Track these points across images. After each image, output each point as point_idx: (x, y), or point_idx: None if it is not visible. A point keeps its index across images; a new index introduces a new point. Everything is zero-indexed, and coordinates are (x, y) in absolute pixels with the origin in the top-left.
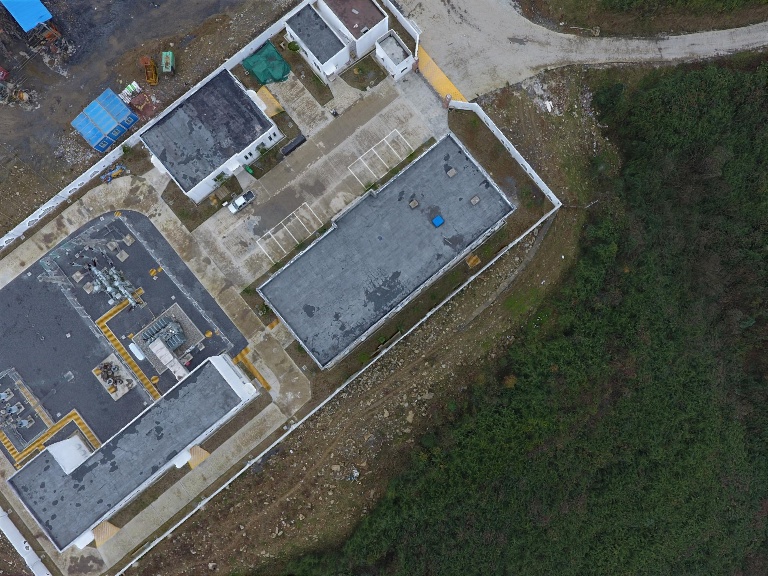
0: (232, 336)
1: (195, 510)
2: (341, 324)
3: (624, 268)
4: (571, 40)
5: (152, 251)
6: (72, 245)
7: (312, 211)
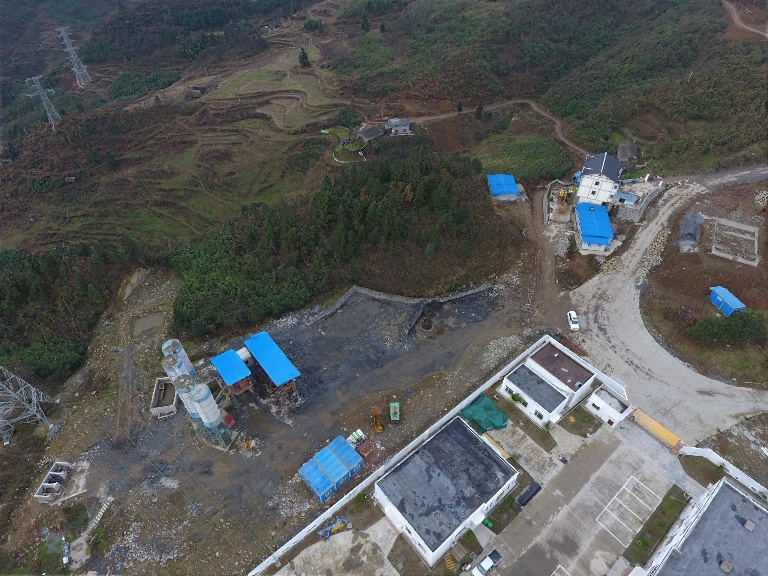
0: None
1: None
2: None
3: None
4: (751, 392)
5: None
6: None
7: None
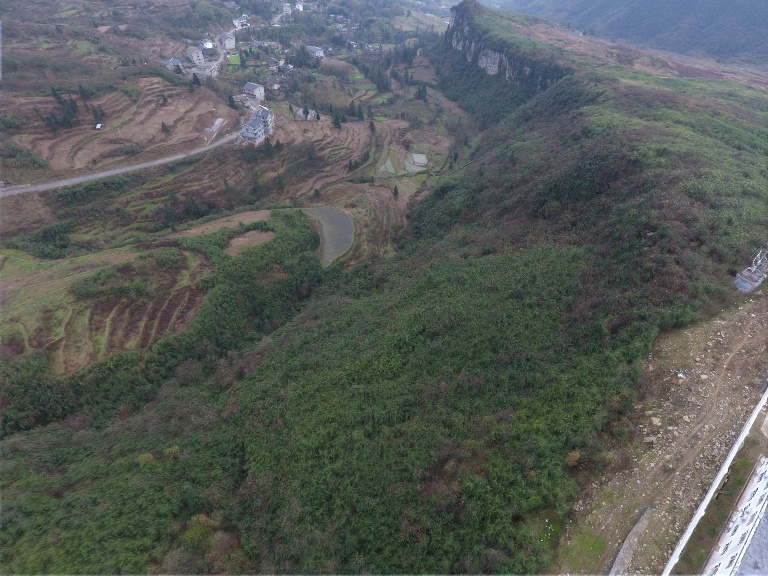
0: None
1: None
2: None
3: None
4: None
5: None
6: None
7: None
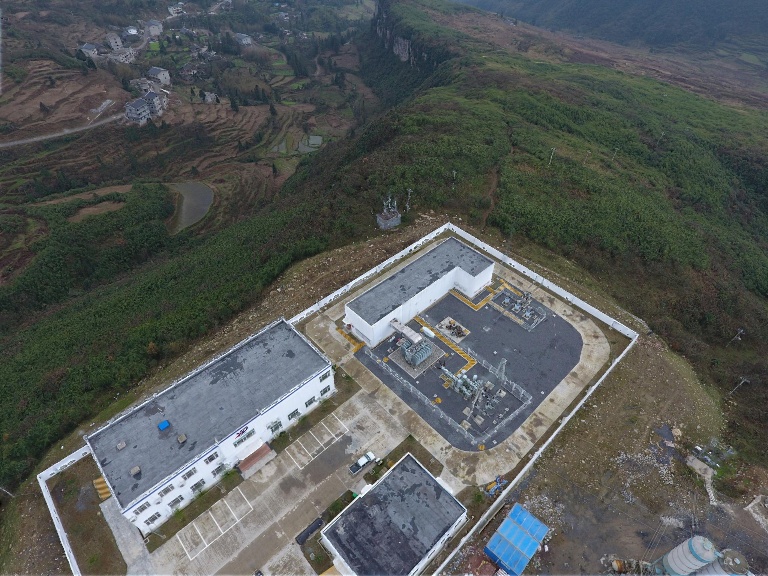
0: (367, 359)
1: (382, 264)
2: (266, 347)
3: (8, 439)
4: None
5: (442, 416)
6: (513, 416)
7: (295, 461)
